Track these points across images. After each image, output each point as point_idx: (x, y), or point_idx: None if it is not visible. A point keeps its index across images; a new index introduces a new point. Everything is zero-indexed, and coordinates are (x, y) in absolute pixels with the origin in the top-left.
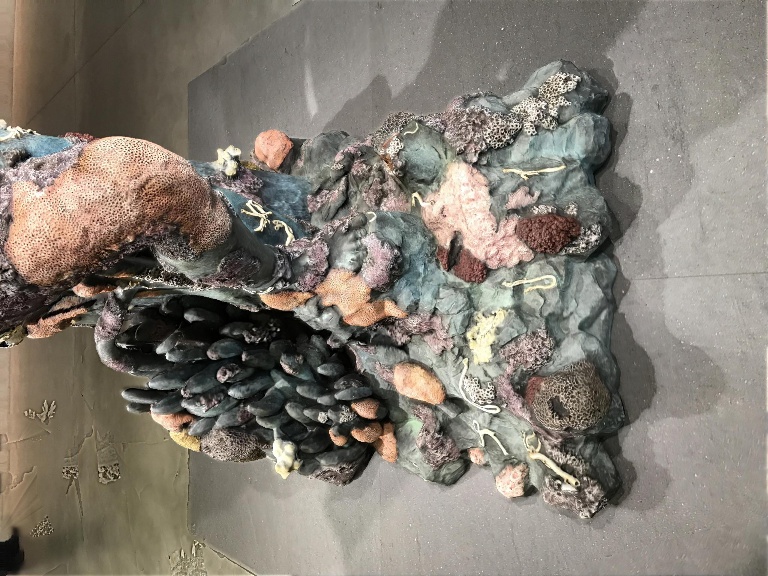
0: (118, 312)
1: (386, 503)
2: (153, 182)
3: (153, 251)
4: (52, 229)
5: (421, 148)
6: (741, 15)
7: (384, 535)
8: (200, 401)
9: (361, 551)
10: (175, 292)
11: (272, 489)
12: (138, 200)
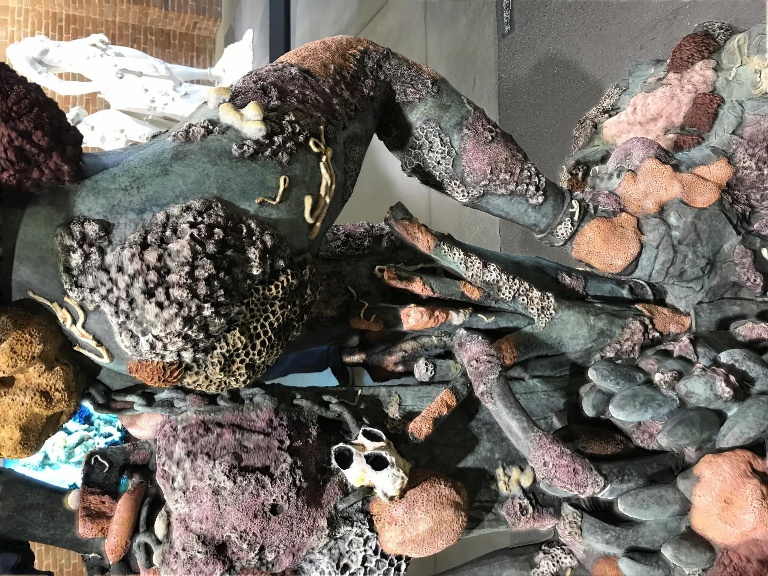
0: (476, 337)
1: None
2: None
3: (412, 140)
4: None
5: None
6: (615, 4)
7: None
8: None
9: None
10: (527, 338)
11: None
12: None
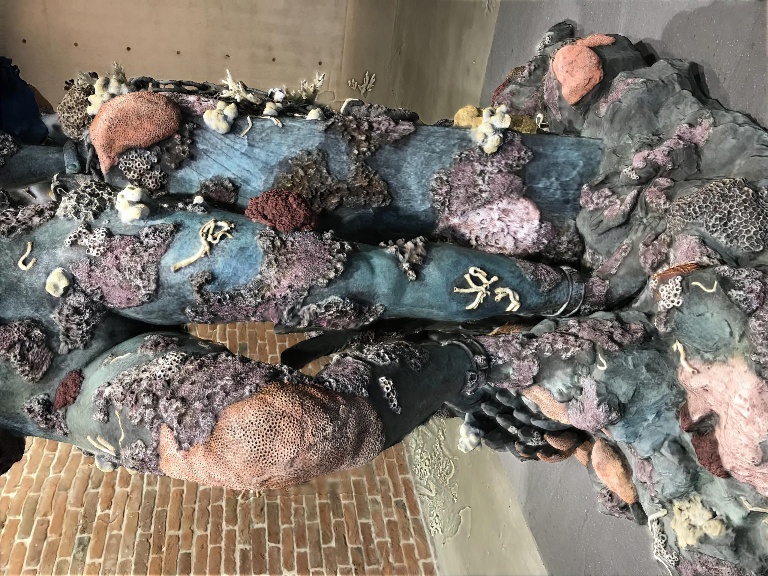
0: None
1: (575, 460)
2: (276, 479)
3: None
4: (191, 478)
5: (707, 314)
6: None
7: (564, 478)
8: None
9: (544, 466)
10: None
11: None
12: (262, 485)
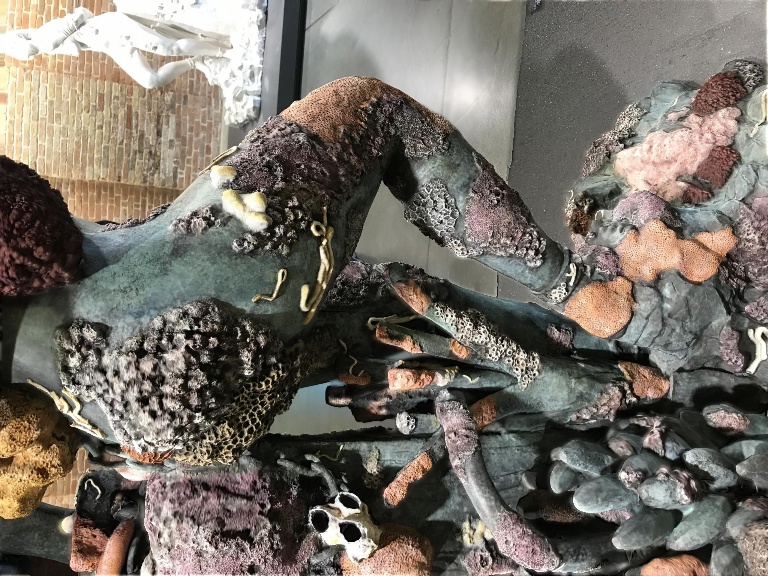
0: (457, 405)
1: None
2: None
3: (417, 196)
4: None
5: None
6: (651, 6)
7: None
8: (658, 473)
9: None
10: (508, 398)
11: None
12: None
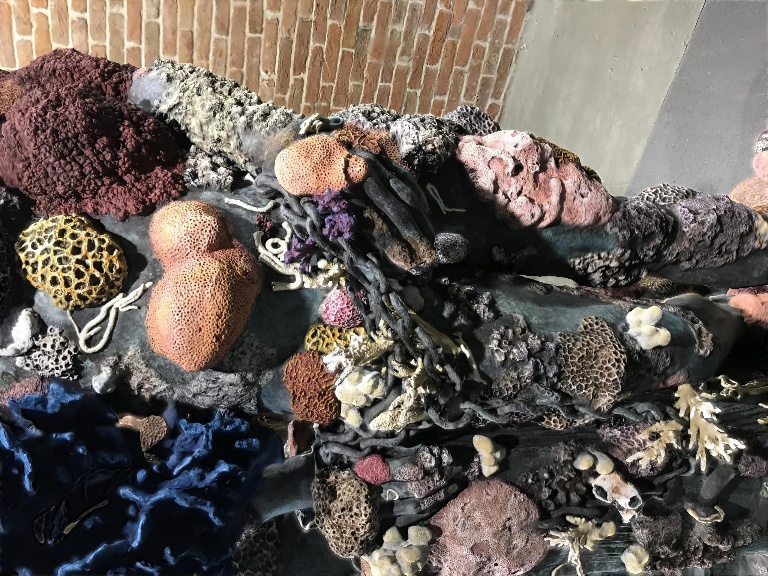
0: None
1: None
2: None
3: None
4: None
5: None
6: None
7: None
8: None
9: None
10: None
11: (765, 74)
12: None
